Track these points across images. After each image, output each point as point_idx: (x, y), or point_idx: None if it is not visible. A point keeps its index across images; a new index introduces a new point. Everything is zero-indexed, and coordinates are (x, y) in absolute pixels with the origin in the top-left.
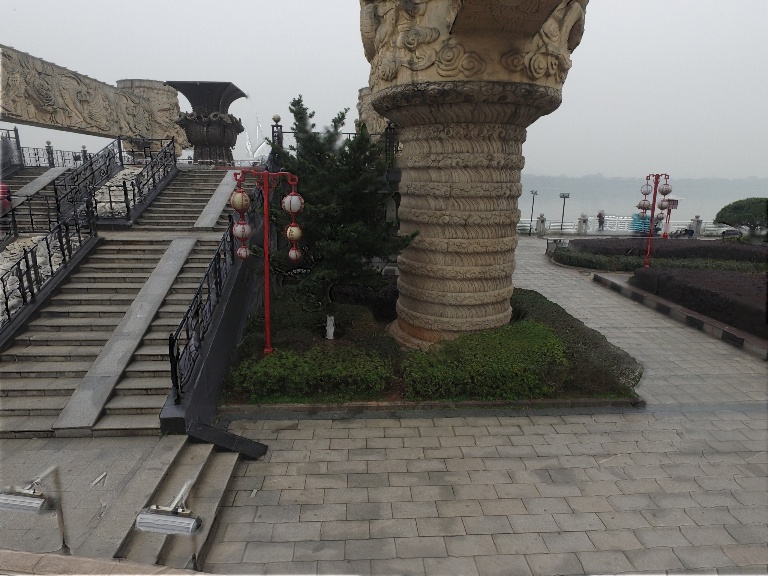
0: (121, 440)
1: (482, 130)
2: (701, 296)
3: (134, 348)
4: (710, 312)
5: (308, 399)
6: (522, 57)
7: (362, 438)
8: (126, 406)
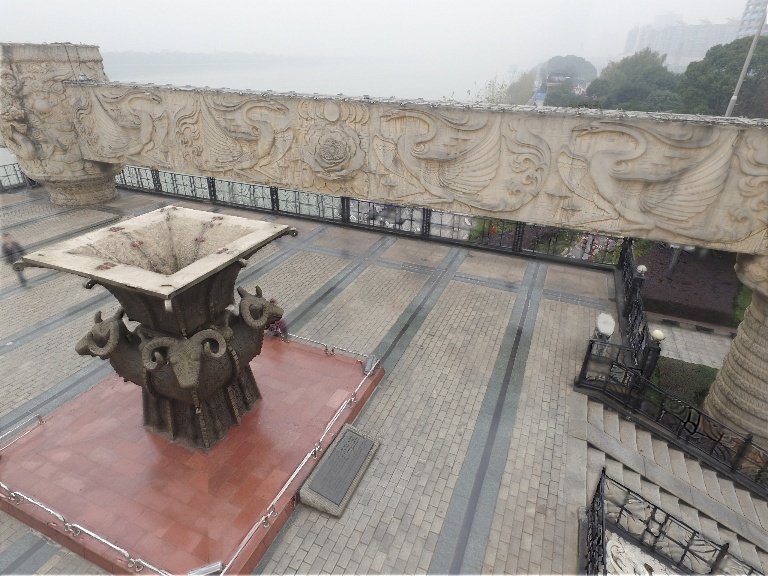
0: None
1: None
2: (664, 305)
3: None
4: (673, 313)
5: None
6: None
7: None
8: None
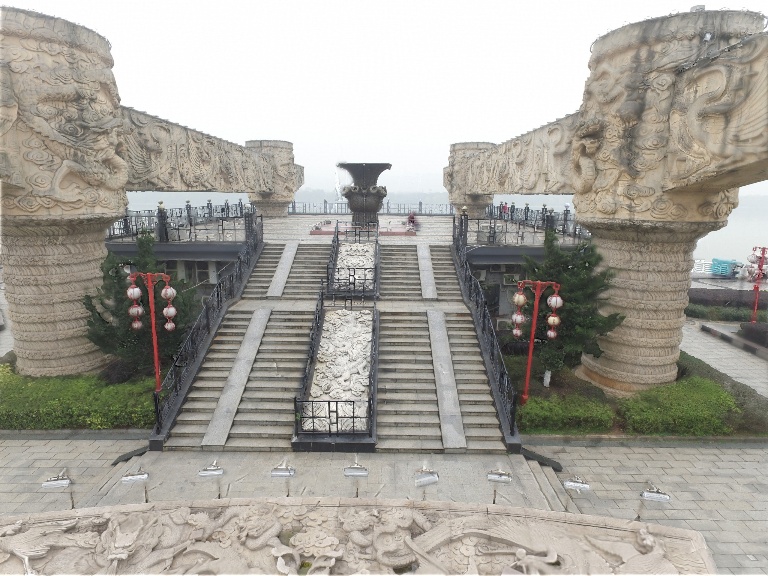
0: (486, 456)
1: (673, 247)
2: None
3: (457, 396)
4: None
5: (560, 432)
6: (712, 207)
7: (616, 460)
8: (477, 435)
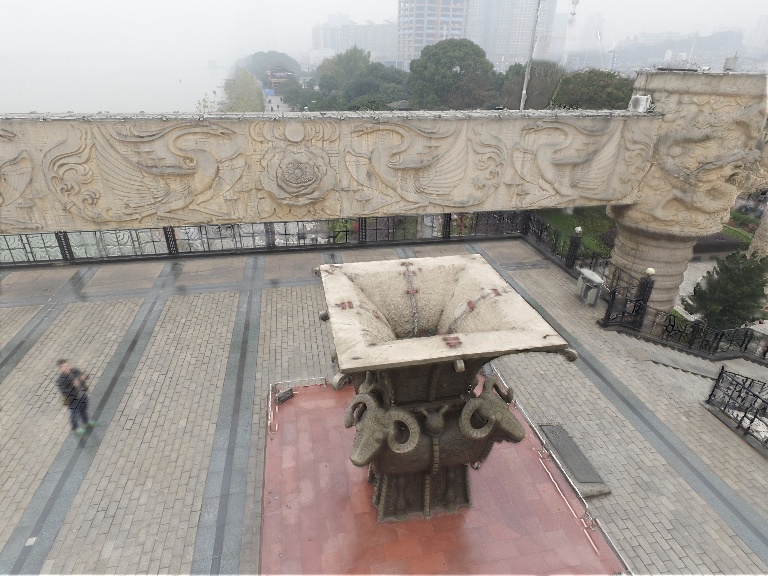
0: None
1: None
2: None
3: None
4: None
5: None
6: None
7: None
8: None
